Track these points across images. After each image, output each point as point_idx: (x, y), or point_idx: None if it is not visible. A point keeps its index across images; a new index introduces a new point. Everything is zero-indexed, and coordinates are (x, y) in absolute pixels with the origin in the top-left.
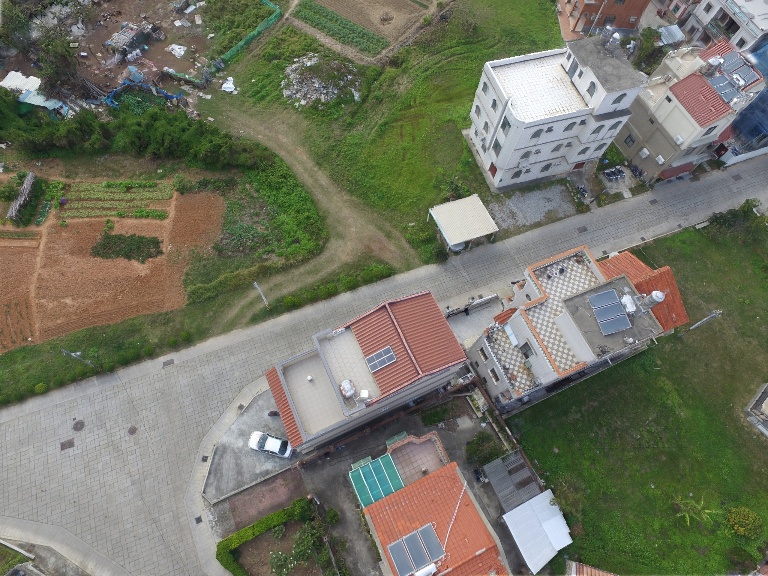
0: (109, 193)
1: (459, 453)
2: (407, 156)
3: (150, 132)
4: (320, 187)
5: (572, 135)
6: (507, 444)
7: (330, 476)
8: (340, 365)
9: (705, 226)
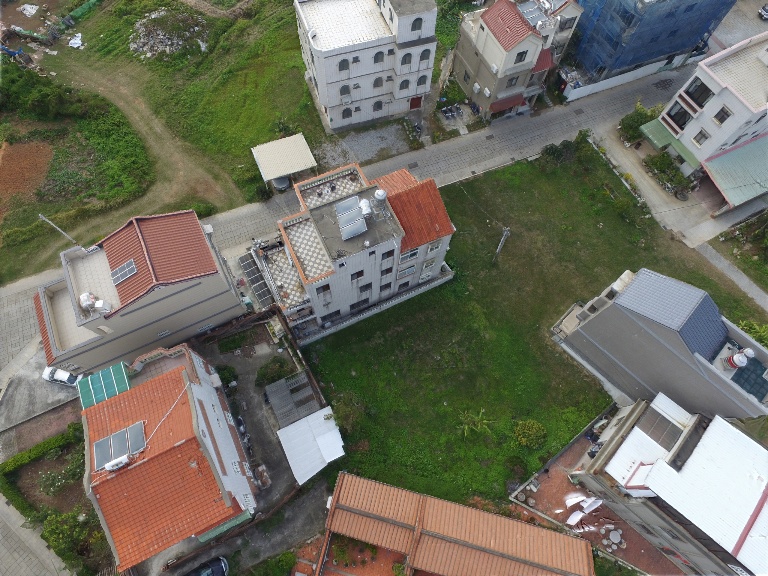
0: None
1: (252, 378)
2: (247, 102)
3: None
4: (154, 134)
5: (387, 67)
6: (299, 367)
7: None
8: (89, 281)
9: (537, 158)
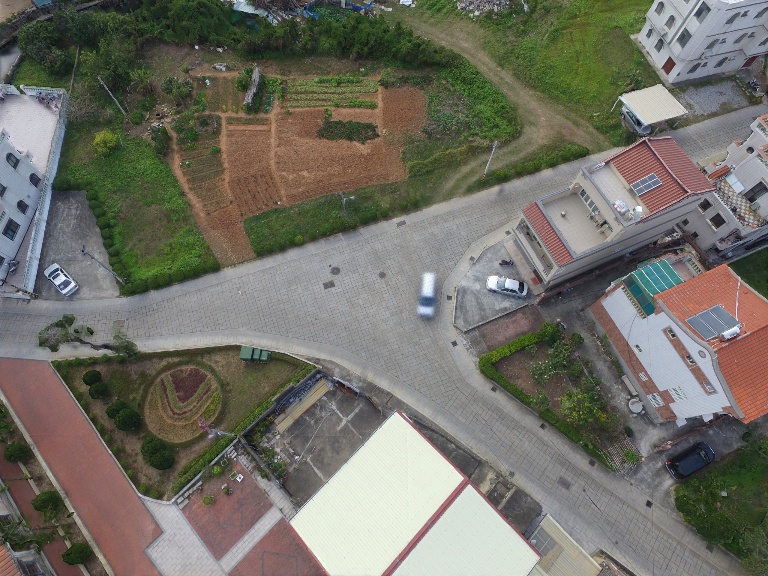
0: (322, 87)
1: None
2: (581, 58)
3: (355, 34)
4: (506, 84)
5: (759, 23)
6: None
7: (564, 311)
8: (605, 192)
9: None
